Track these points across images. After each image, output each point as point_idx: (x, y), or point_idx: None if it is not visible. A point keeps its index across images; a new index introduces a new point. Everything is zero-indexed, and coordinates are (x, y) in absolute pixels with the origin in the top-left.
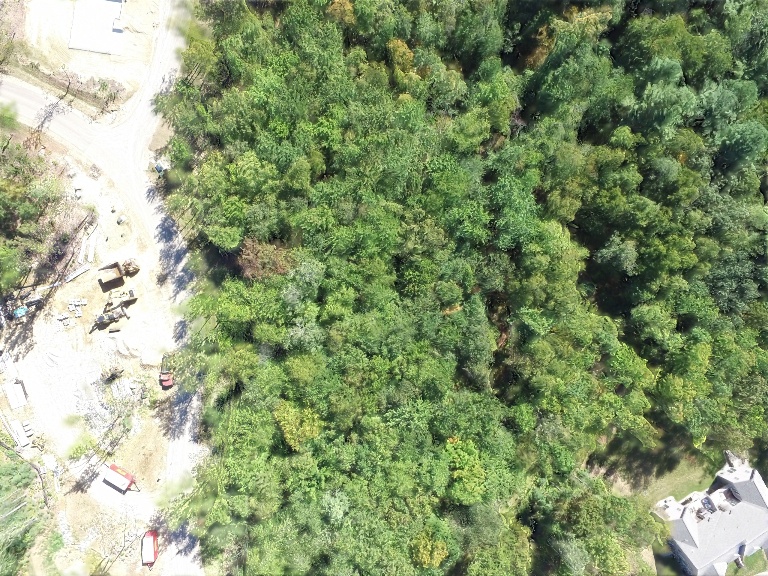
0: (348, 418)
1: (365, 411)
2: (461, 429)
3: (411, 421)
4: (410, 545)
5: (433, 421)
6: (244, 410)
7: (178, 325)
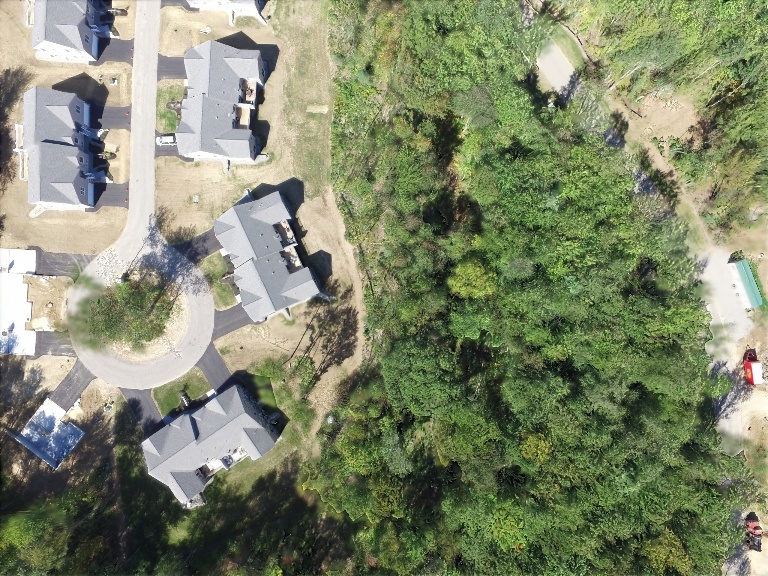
0: (628, 570)
1: (610, 574)
2: (515, 561)
3: (566, 568)
4: (553, 446)
5: (545, 569)
6: (720, 564)
7: (748, 575)
